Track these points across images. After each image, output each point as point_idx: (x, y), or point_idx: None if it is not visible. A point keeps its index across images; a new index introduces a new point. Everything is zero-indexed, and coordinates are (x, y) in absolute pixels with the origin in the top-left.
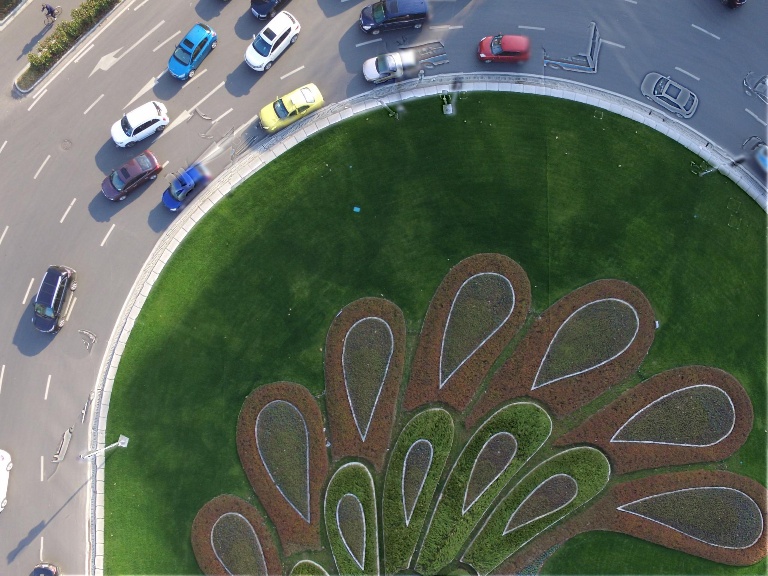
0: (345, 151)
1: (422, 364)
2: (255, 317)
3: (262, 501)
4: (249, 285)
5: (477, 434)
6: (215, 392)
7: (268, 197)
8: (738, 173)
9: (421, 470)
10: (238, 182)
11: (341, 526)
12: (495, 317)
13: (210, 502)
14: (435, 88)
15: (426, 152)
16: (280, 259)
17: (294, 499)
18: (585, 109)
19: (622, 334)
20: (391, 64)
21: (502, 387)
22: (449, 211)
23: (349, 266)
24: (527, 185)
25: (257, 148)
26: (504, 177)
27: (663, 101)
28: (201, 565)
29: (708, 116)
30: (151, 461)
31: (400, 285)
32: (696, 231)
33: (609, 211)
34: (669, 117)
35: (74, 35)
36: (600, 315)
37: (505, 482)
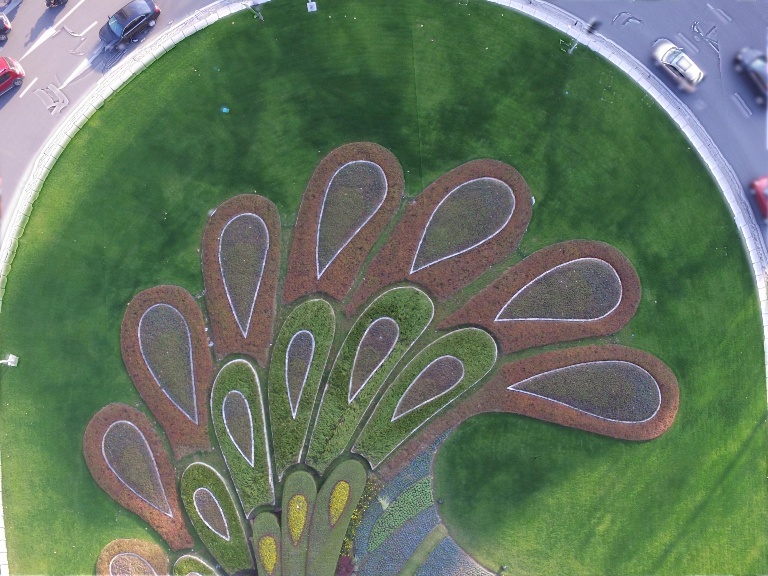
0: (213, 55)
1: (298, 255)
2: (132, 224)
3: (149, 406)
4: (125, 194)
5: (358, 321)
6: (98, 302)
7: (140, 107)
8: (610, 49)
9: (303, 361)
10: (110, 95)
11: (228, 424)
12: (368, 203)
13: (99, 412)
14: None
15: (292, 49)
16: (153, 165)
17: (180, 401)
18: None
19: (498, 212)
20: None
21: (380, 273)
22: (317, 104)
23: (221, 166)
24: (394, 73)
25: (128, 61)
26: (371, 67)
27: None
28: (95, 477)
29: None
30: (41, 377)
31: (273, 180)
32: (569, 107)
33: (479, 93)
34: None
35: None
36: (474, 194)
37: (390, 368)
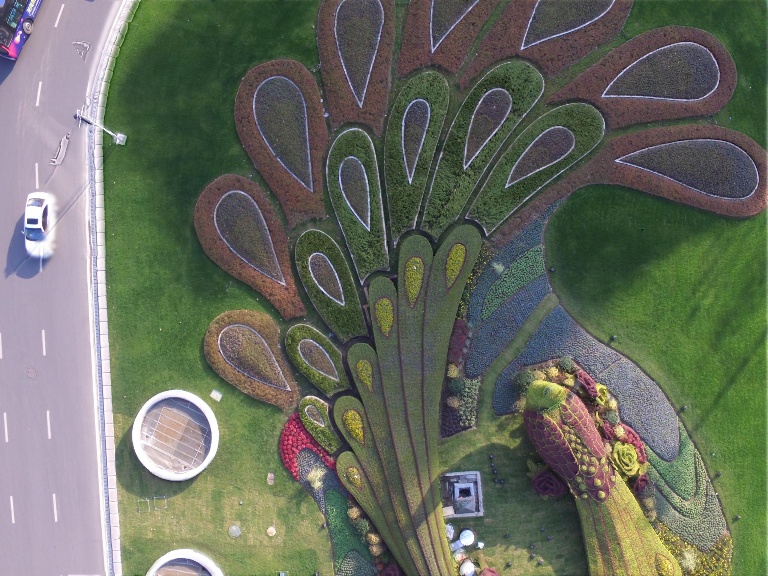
0: None
1: (413, 29)
2: (247, 4)
3: (264, 175)
4: None
5: (472, 92)
6: (211, 78)
7: None
8: None
9: (420, 128)
10: None
11: (344, 188)
12: None
13: (211, 184)
14: None
15: None
16: None
17: (296, 169)
18: None
19: None
20: None
21: (492, 47)
22: None
23: None
24: None
25: None
26: None
27: None
28: (205, 248)
29: None
30: (150, 154)
31: None
32: None
33: None
34: None
35: None
36: None
37: (503, 136)
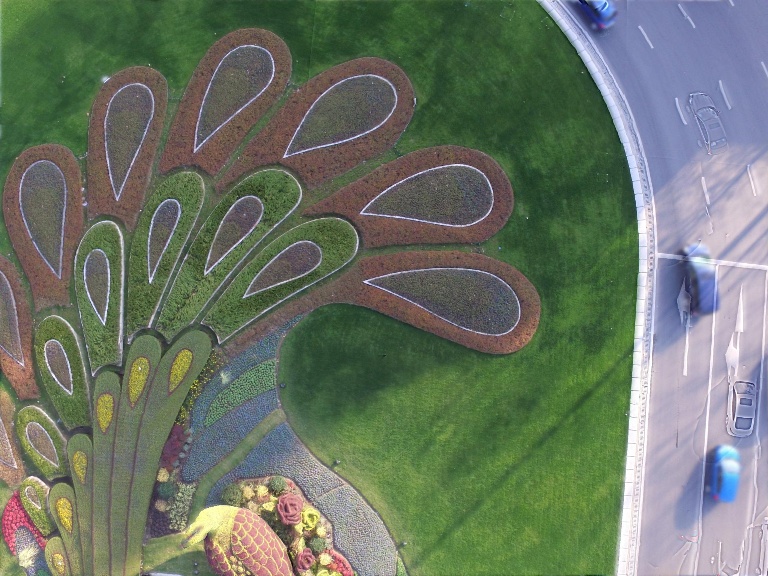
0: None
1: (178, 127)
2: (32, 85)
3: (19, 256)
4: (31, 56)
5: (225, 196)
6: None
7: None
8: None
9: (167, 228)
10: None
11: (87, 280)
12: (252, 86)
13: None
14: None
15: None
16: (60, 31)
17: (47, 254)
18: None
19: (378, 108)
20: None
21: (254, 153)
22: None
23: (122, 38)
24: None
25: None
26: None
27: None
28: None
29: None
30: None
31: (167, 56)
32: (466, 19)
33: None
34: None
35: None
36: (357, 89)
37: (249, 245)
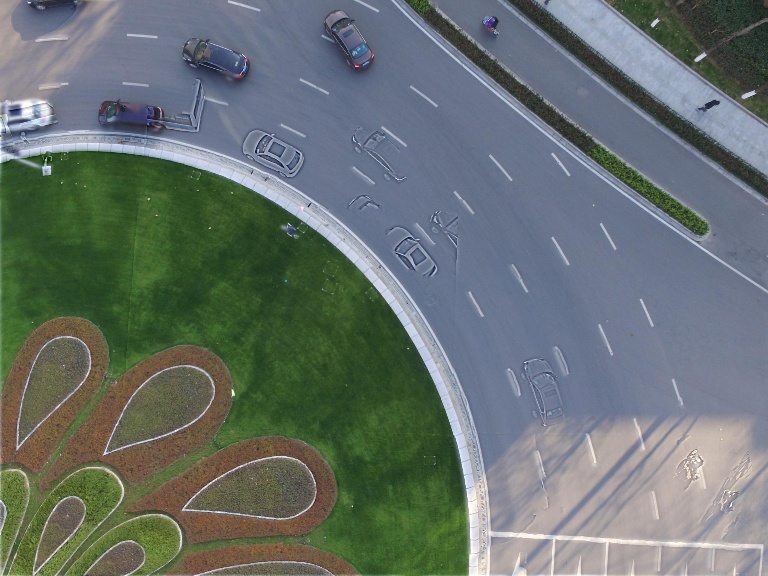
0: None
1: None
2: None
3: None
4: None
5: (48, 497)
6: None
7: None
8: (342, 234)
9: None
10: None
11: None
12: (69, 381)
13: None
14: (39, 149)
15: (21, 214)
16: None
17: None
18: (182, 169)
19: (195, 402)
20: (1, 126)
21: (74, 451)
22: (37, 274)
23: None
24: (114, 248)
25: None
26: (92, 240)
27: (265, 160)
28: None
29: (313, 175)
30: None
31: None
32: (286, 296)
33: (195, 275)
34: (274, 176)
35: None
36: (173, 382)
37: (74, 546)
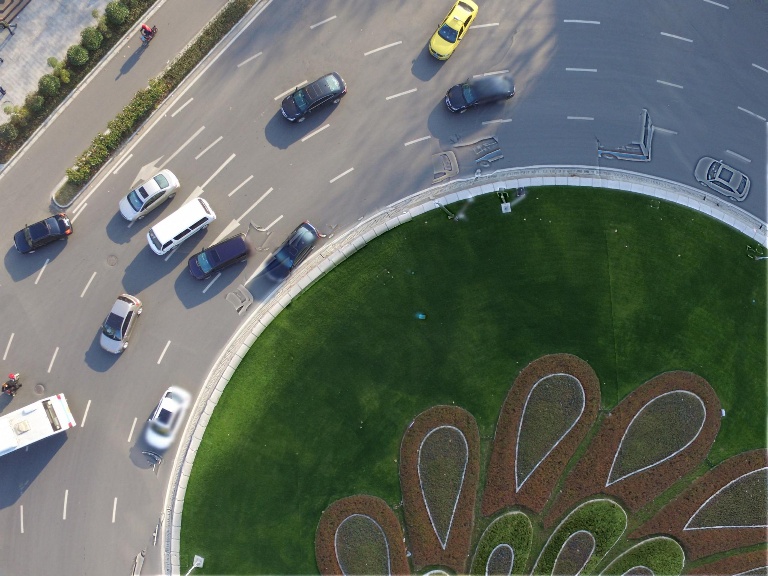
0: (406, 257)
1: (498, 470)
2: (326, 432)
3: None
4: (318, 400)
5: (556, 534)
6: (290, 509)
7: (330, 308)
8: None
9: (503, 574)
10: (298, 293)
11: None
12: (567, 418)
13: None
14: (492, 186)
15: (488, 254)
16: (348, 372)
17: None
18: (642, 199)
19: (691, 425)
20: (446, 163)
21: (577, 486)
22: (515, 313)
23: (418, 375)
24: (590, 281)
25: (315, 257)
26: (567, 275)
27: (717, 185)
28: None
29: (760, 198)
30: None
31: (471, 391)
32: (755, 315)
33: (671, 302)
34: (723, 201)
35: (116, 149)
36: (669, 408)
37: None
